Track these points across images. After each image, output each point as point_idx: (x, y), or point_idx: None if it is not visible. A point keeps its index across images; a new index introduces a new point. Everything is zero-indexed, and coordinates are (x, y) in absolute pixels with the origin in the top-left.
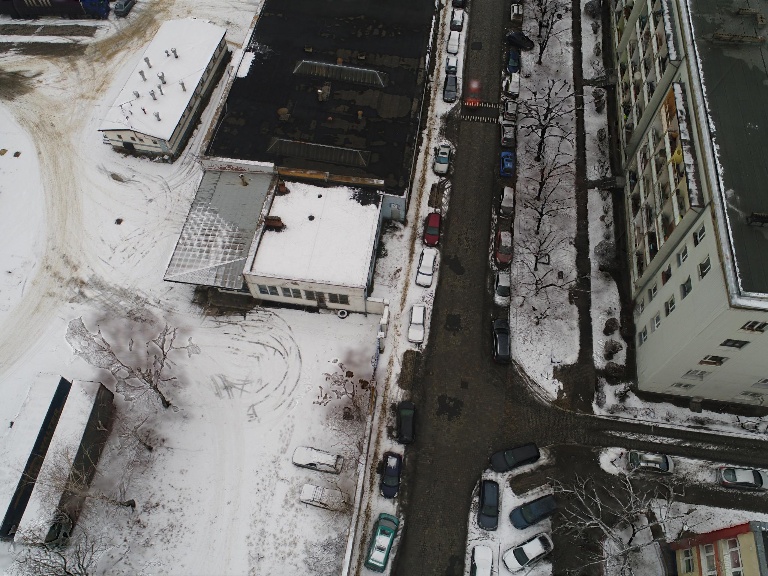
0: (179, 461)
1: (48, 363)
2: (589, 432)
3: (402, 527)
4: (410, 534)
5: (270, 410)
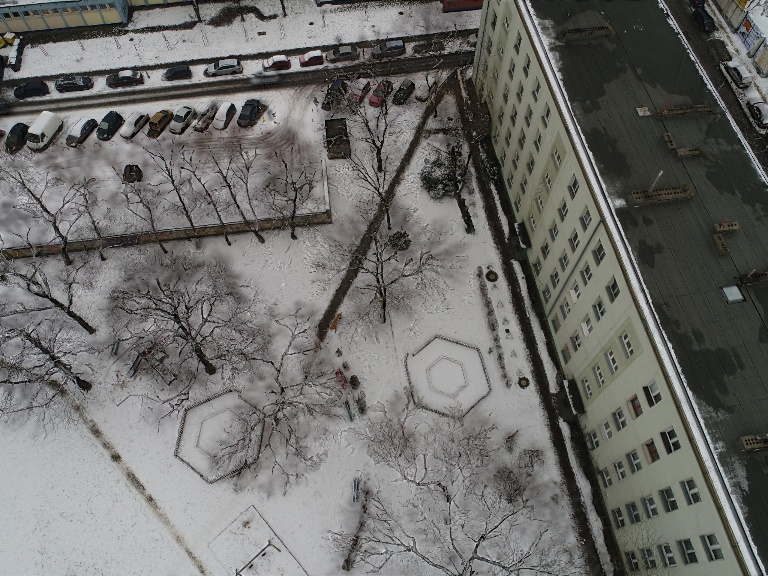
0: None
1: None
2: None
3: None
4: None
5: None
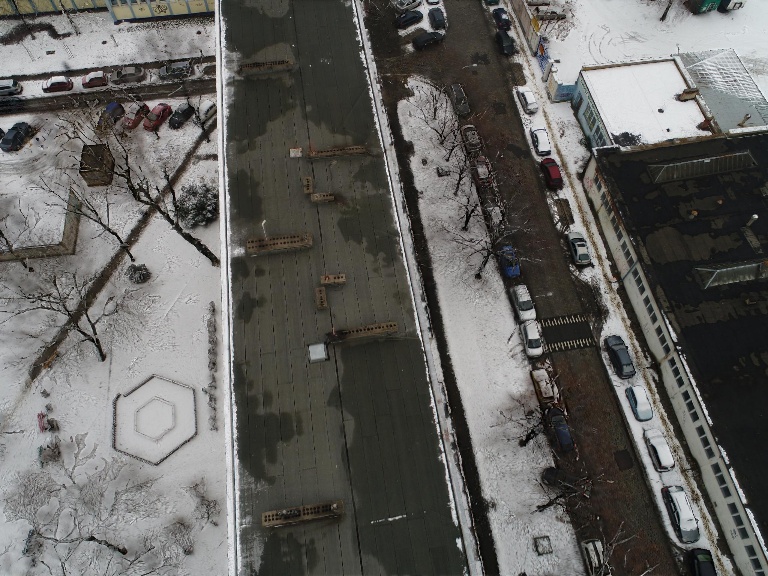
0: (630, 0)
1: (759, 24)
2: (381, 66)
3: (483, 4)
4: (477, 2)
5: (596, 32)
